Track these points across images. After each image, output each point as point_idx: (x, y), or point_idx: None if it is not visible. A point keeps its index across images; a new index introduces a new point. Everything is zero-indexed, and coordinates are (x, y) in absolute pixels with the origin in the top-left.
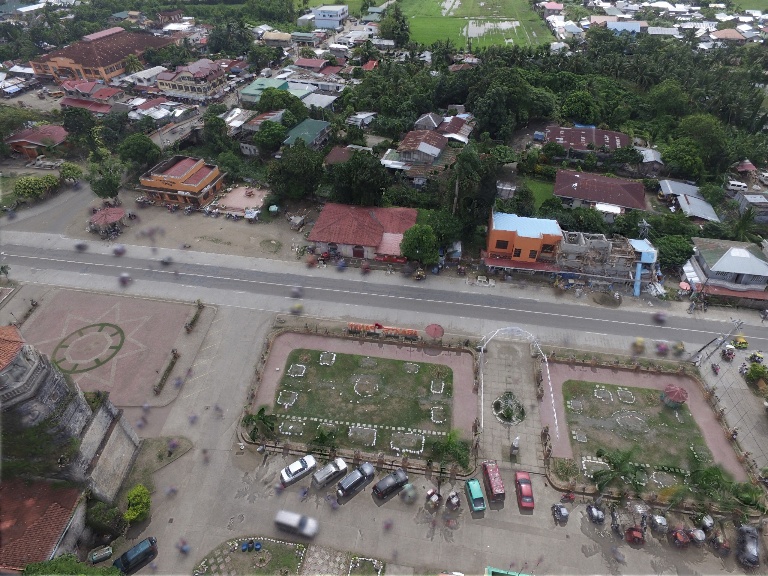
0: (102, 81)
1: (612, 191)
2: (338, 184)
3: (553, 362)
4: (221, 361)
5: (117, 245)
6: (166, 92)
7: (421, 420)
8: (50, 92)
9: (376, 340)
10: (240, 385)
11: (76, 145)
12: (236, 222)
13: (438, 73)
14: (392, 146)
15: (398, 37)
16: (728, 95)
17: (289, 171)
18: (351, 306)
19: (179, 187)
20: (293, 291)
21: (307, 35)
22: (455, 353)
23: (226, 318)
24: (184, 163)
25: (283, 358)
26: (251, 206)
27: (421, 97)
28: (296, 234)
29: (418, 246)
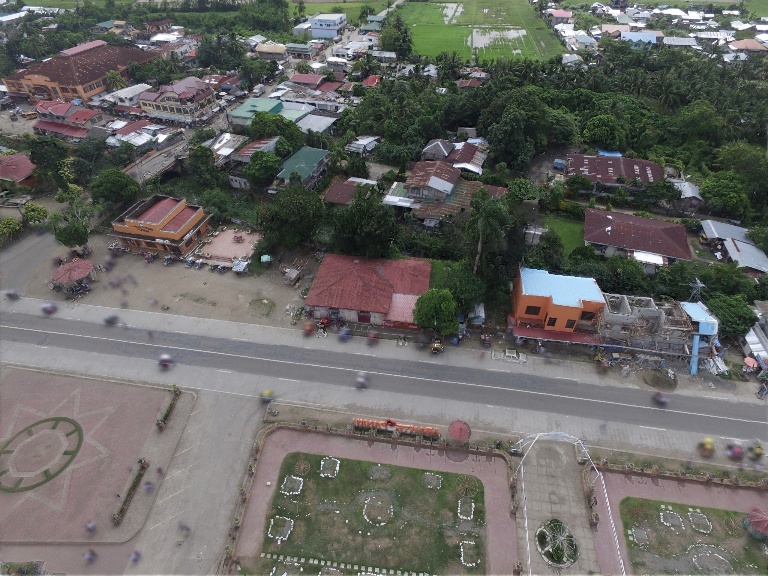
0: (81, 100)
1: (651, 237)
2: (340, 234)
3: (605, 471)
4: (200, 471)
5: (83, 307)
6: (149, 113)
7: (448, 562)
8: (23, 113)
9: (388, 440)
10: (222, 508)
11: (45, 179)
12: (222, 275)
13: (445, 91)
14: (398, 177)
15: (400, 49)
16: (767, 118)
17: (283, 219)
18: (357, 390)
19: (157, 234)
20: (288, 369)
21: (303, 46)
22: (485, 458)
23: (207, 408)
24: (164, 204)
25: (275, 466)
26: (240, 255)
27: (429, 121)
28: (291, 290)
29: (435, 315)
